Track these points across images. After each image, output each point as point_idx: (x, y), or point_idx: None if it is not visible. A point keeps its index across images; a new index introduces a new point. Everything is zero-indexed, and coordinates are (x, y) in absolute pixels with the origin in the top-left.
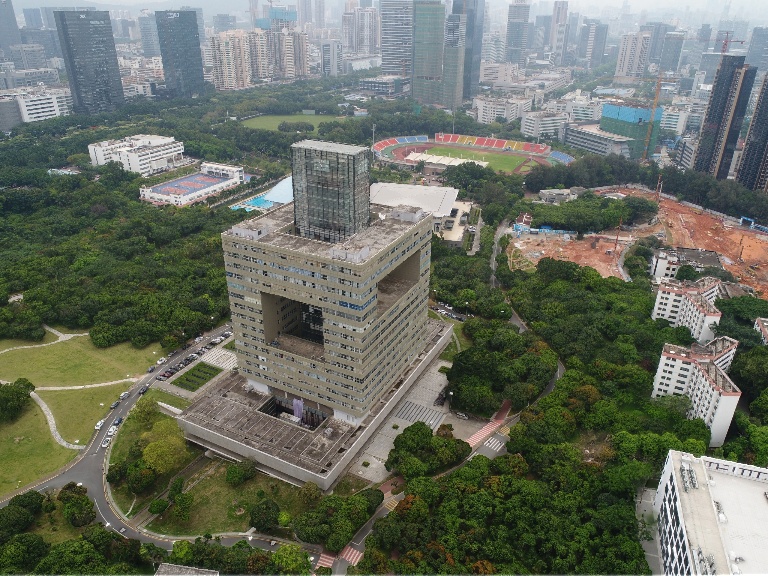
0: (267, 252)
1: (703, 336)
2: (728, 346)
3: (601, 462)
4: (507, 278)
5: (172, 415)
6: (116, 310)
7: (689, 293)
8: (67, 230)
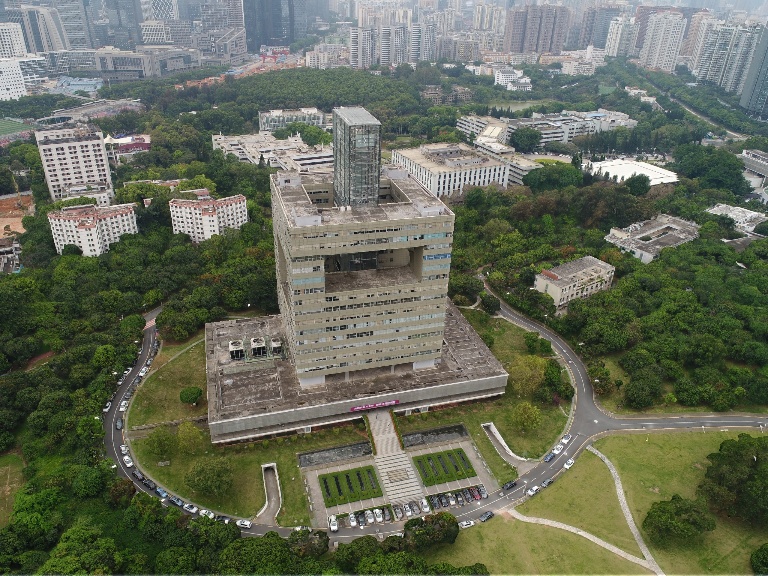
0: None
1: (136, 227)
2: None
3: None
4: (25, 349)
5: (494, 443)
6: None
7: None
8: None
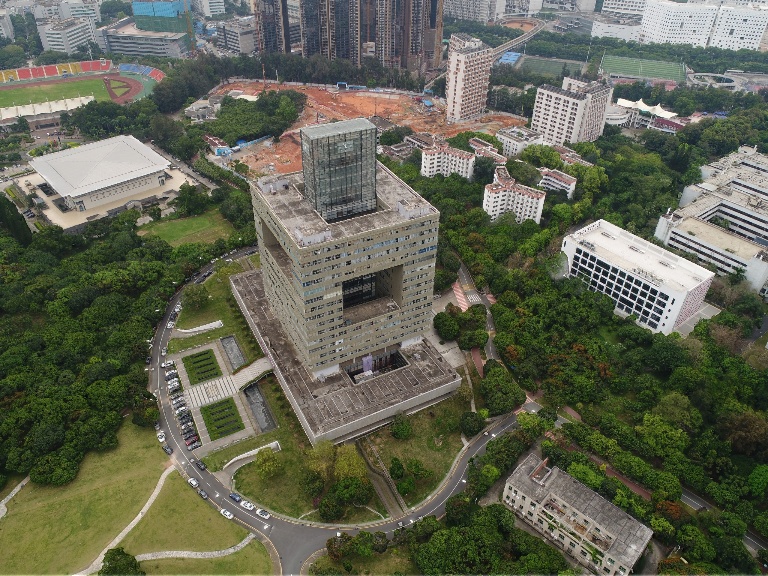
0: (352, 242)
1: (469, 173)
2: (504, 171)
3: (528, 268)
4: None
5: None
6: (26, 439)
7: (445, 149)
8: None
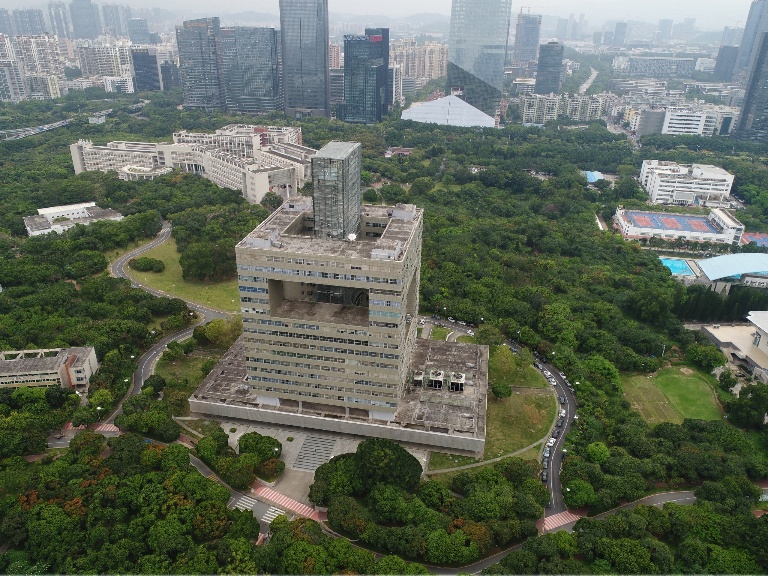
0: None
1: None
2: None
3: None
4: (704, 491)
5: None
6: None
7: None
8: (503, 212)
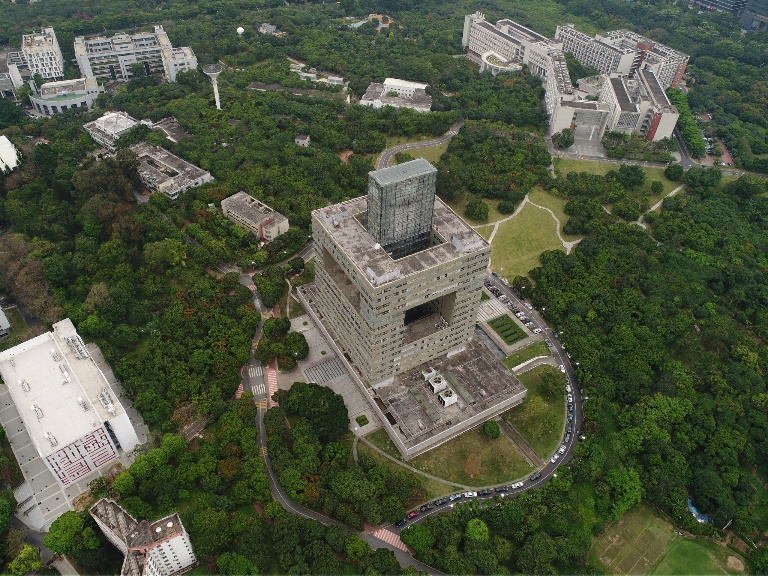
0: None
1: None
2: None
3: None
4: None
5: None
6: None
7: None
8: None
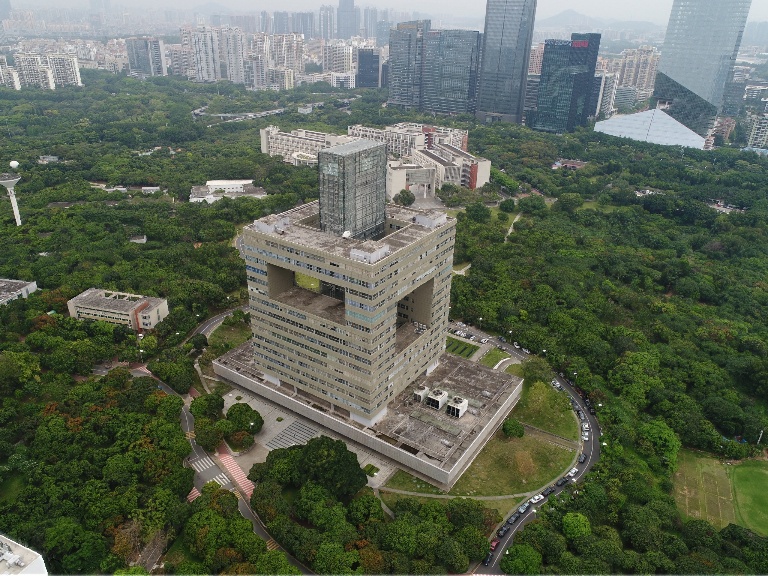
0: None
1: None
2: None
3: None
4: None
5: None
6: None
7: None
8: (651, 242)
